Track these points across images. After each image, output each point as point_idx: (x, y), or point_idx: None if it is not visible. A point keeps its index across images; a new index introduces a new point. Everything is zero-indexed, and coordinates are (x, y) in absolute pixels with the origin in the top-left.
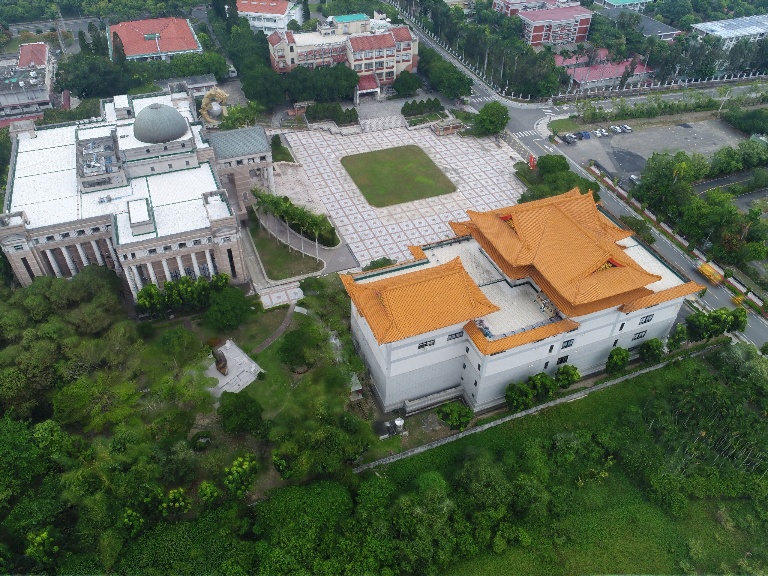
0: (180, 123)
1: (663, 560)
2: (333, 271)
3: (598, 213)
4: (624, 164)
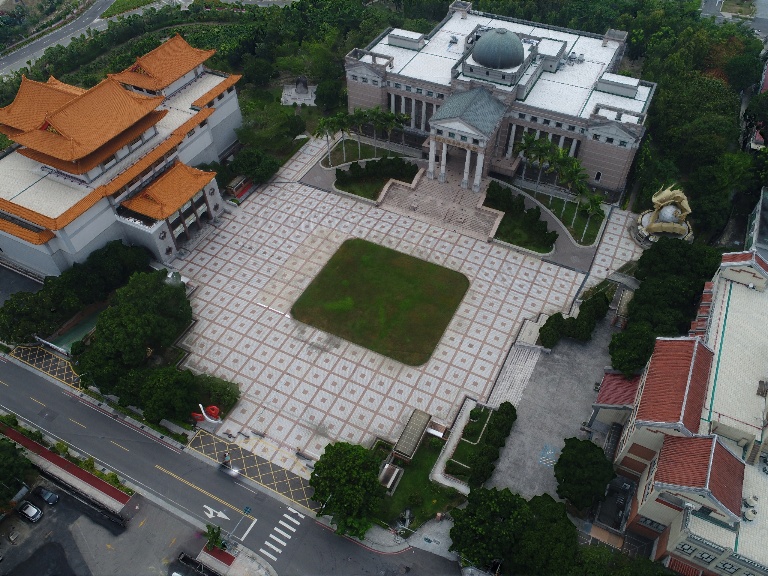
0: (481, 51)
1: (7, 145)
2: (313, 168)
3: (41, 127)
4: (56, 567)
